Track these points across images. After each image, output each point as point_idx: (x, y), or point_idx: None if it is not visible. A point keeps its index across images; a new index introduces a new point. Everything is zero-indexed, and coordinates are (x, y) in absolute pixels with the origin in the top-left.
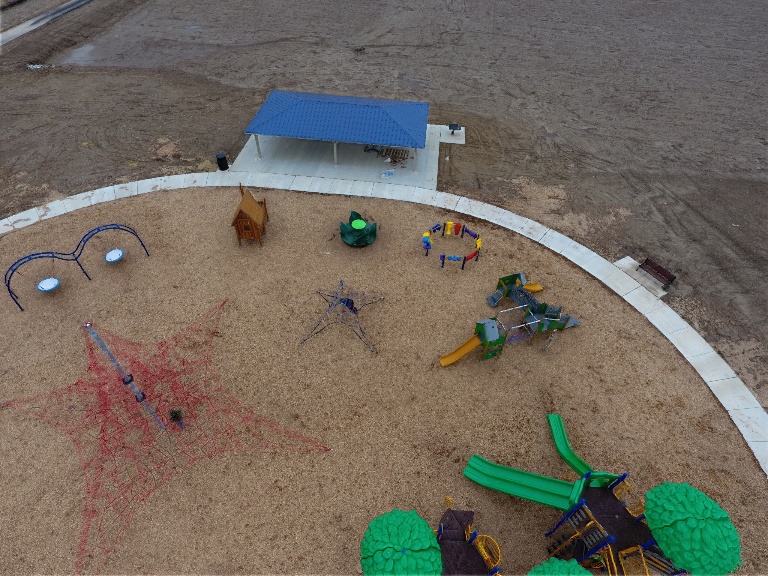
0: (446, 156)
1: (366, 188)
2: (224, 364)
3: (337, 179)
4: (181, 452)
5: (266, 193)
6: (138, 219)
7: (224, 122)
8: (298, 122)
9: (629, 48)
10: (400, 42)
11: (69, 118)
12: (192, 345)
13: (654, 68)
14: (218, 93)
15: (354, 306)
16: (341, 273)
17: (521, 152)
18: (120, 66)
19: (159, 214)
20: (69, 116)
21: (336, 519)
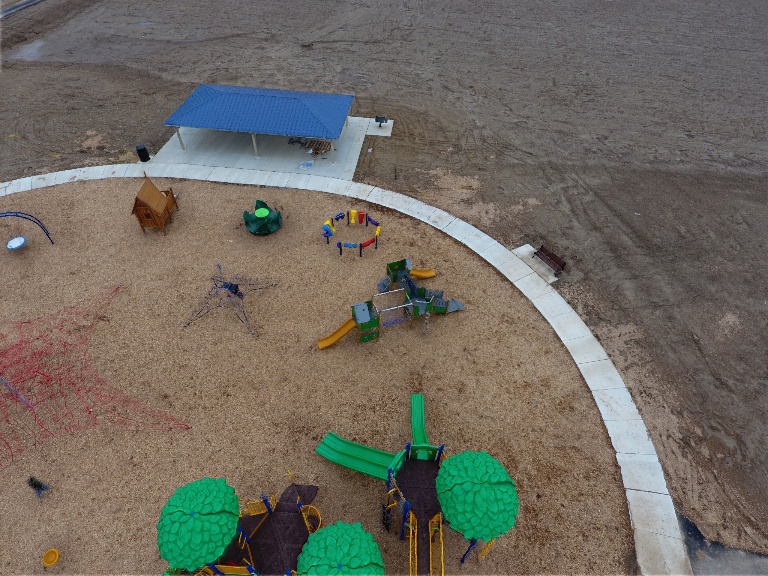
0: (369, 148)
1: (282, 179)
2: (105, 347)
3: (255, 170)
4: (44, 430)
5: (182, 183)
6: (49, 208)
7: (155, 115)
8: (217, 114)
9: (576, 44)
10: (350, 38)
11: (1, 111)
12: (77, 329)
13: (597, 63)
14: (156, 87)
15: (240, 291)
16: (239, 260)
17: (445, 144)
18: (65, 61)
19: (71, 204)
20: (1, 109)
21: None
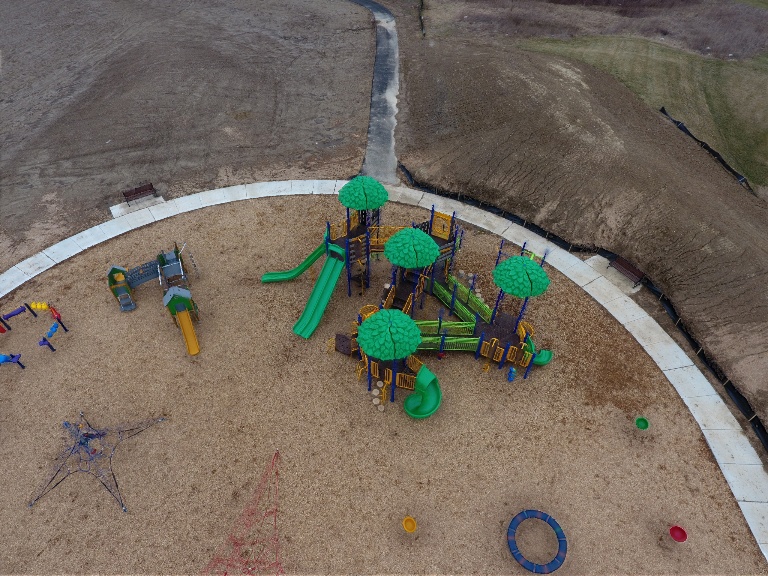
0: None
1: None
2: None
3: None
4: None
5: None
6: None
7: None
8: None
9: None
10: None
11: None
12: None
13: None
14: None
15: None
16: (5, 475)
17: None
18: None
19: None
20: None
21: (344, 435)
